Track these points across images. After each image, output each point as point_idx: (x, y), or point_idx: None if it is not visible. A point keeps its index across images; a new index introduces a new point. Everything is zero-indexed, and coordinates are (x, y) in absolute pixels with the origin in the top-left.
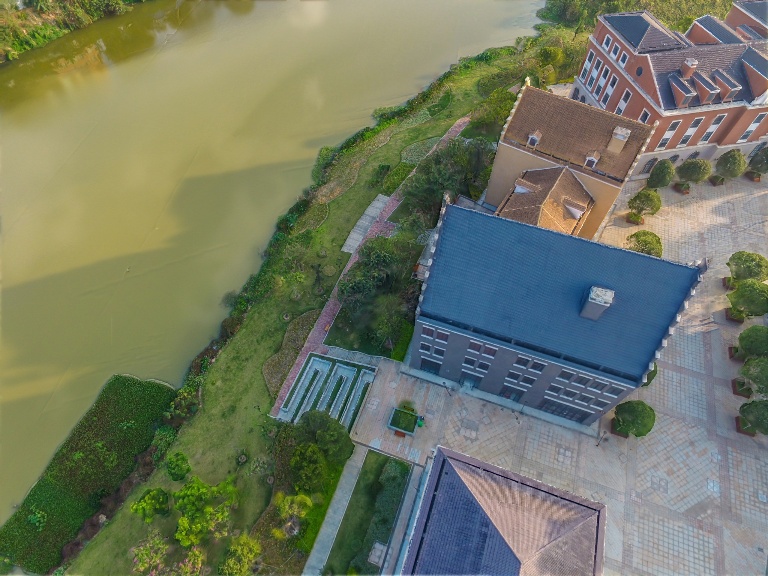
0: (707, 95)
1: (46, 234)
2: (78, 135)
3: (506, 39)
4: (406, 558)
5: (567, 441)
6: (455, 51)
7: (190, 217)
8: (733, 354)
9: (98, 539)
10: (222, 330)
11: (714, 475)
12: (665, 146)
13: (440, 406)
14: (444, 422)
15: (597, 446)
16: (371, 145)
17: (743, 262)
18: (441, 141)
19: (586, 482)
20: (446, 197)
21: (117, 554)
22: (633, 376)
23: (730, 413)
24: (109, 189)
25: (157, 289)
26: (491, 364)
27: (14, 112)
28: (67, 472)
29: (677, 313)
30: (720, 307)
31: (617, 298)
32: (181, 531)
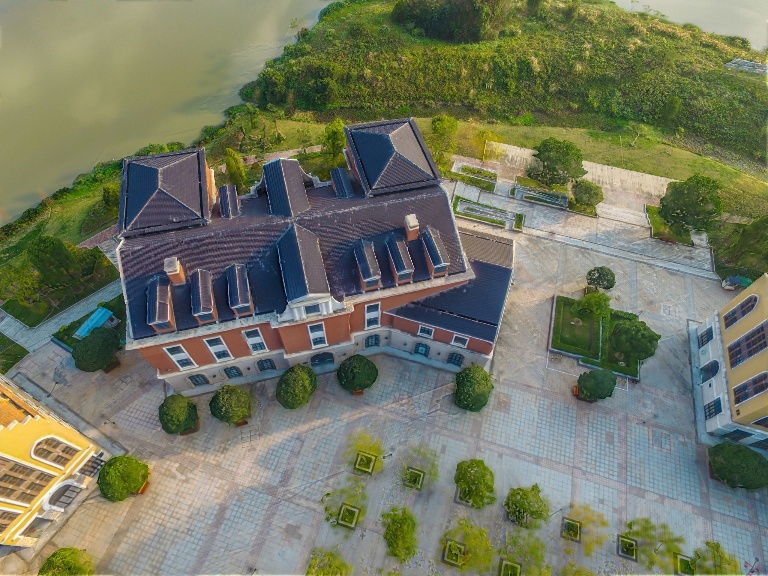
0: (196, 316)
1: None
2: None
3: (178, 131)
4: None
5: None
6: (99, 152)
7: None
8: None
9: None
10: None
11: None
12: (196, 364)
13: None
14: None
15: None
16: None
17: None
18: None
19: None
20: None
21: None
22: None
23: None
24: None
25: None
26: None
27: None
28: None
29: None
30: None
31: None
32: None
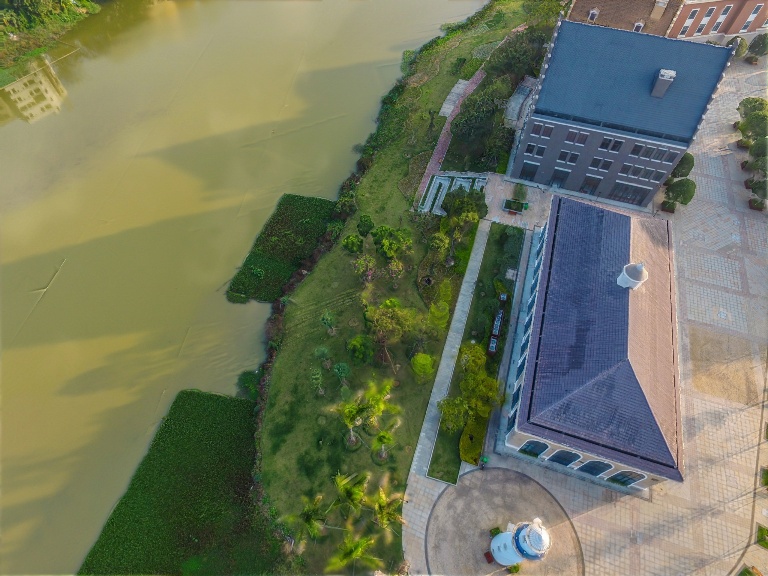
0: None
1: (199, 110)
2: (200, 44)
3: None
4: (545, 246)
5: None
6: None
7: (311, 97)
8: (744, 165)
9: (306, 281)
10: (359, 165)
11: (736, 231)
12: (685, 34)
13: (537, 198)
14: (542, 207)
15: None
16: (445, 48)
17: (750, 103)
18: (511, 32)
19: None
20: (562, 13)
21: (324, 287)
22: (686, 138)
23: (744, 199)
24: (239, 80)
25: (299, 143)
26: (580, 154)
27: (140, 28)
28: (270, 248)
29: (717, 83)
30: (733, 141)
31: (677, 78)
32: (386, 246)
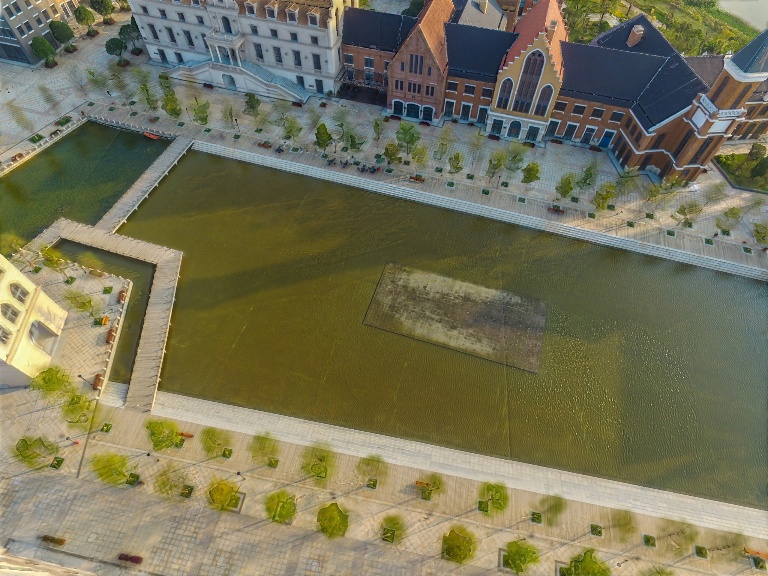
0: None
1: None
2: None
3: None
4: None
5: (17, 70)
6: None
7: None
8: None
9: None
10: None
11: (87, 79)
12: None
13: None
14: None
15: (32, 71)
16: None
17: None
18: None
19: (14, 82)
20: None
21: None
22: None
23: None
24: None
25: None
26: None
27: None
28: None
29: None
30: None
31: None
32: None
